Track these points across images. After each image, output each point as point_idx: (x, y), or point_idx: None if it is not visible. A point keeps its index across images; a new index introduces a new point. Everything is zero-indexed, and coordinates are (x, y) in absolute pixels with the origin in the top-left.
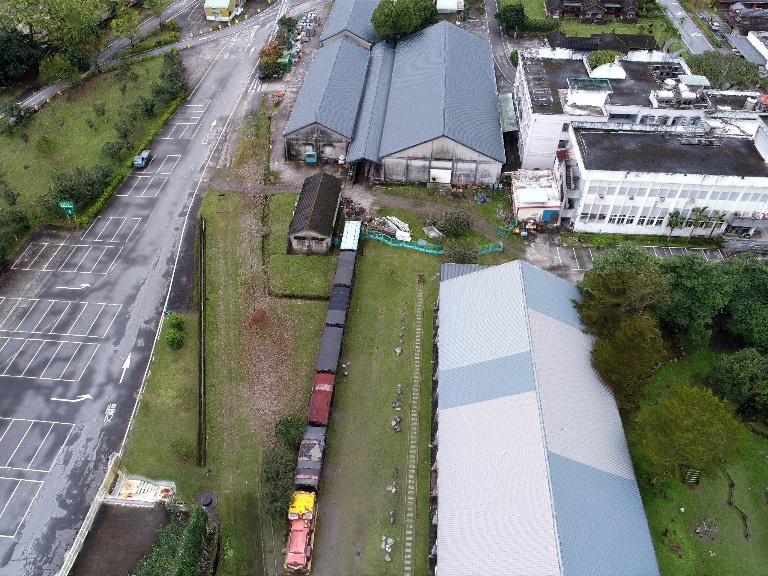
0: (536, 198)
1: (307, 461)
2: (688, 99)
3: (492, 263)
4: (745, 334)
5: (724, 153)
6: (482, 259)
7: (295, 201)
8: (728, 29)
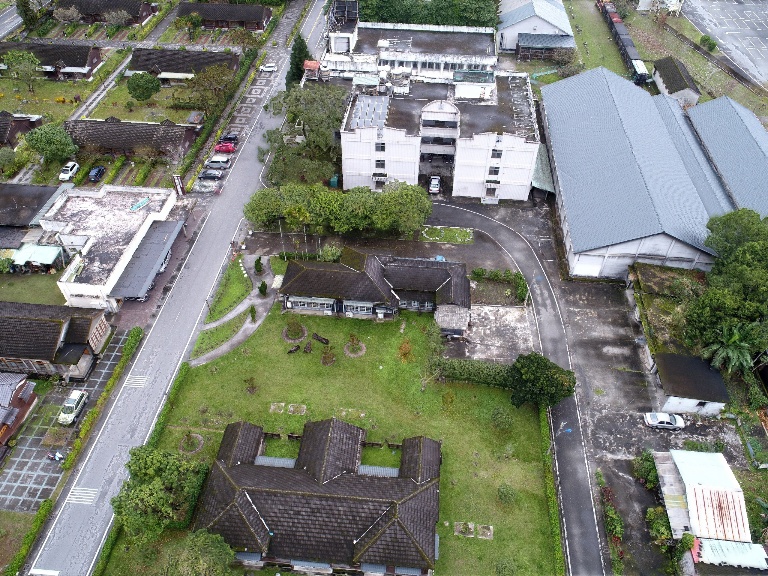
0: None
1: None
2: None
3: (540, 70)
4: None
5: None
6: None
7: None
8: (45, 406)
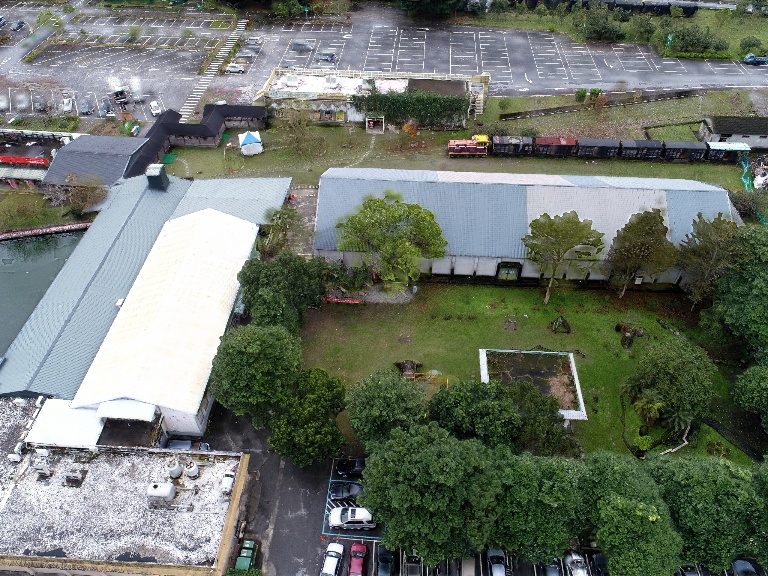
0: None
1: (508, 138)
2: None
3: None
4: None
5: None
6: None
7: None
8: None
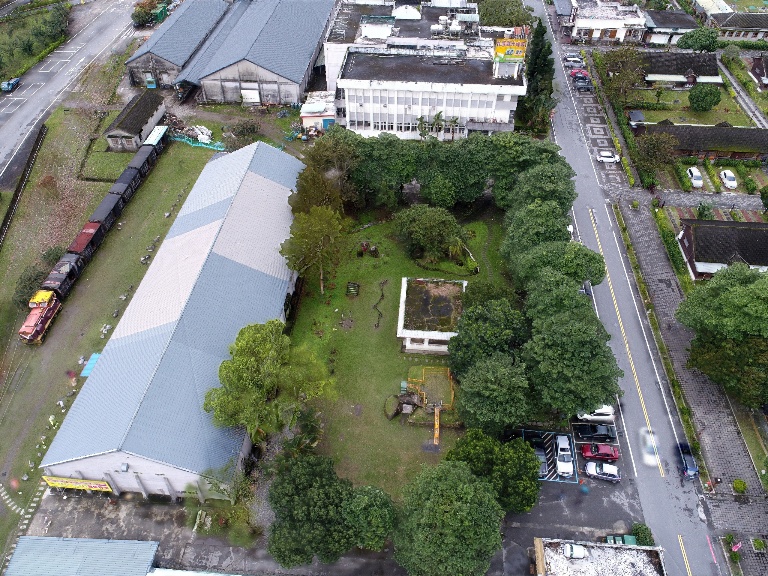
0: (315, 109)
1: (56, 273)
2: (455, 31)
3: None
4: (430, 197)
5: (464, 70)
6: None
7: None
8: None
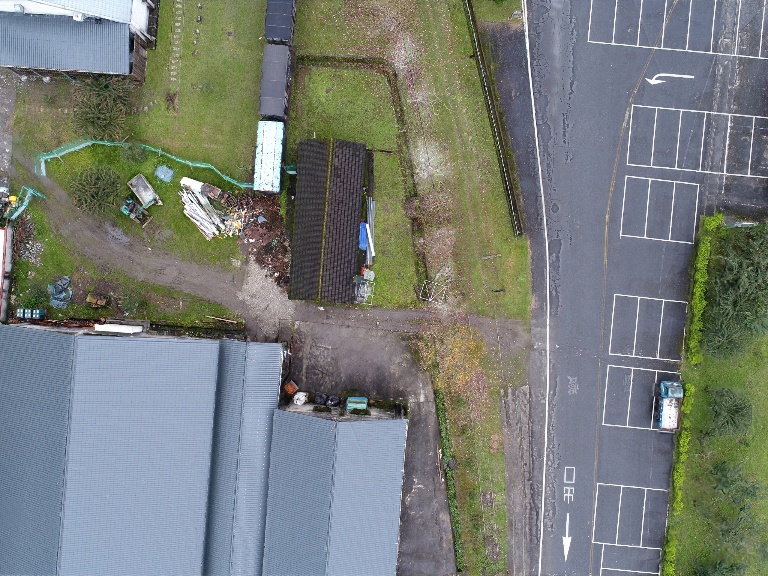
0: None
1: None
2: None
3: (63, 129)
4: None
5: None
6: (77, 138)
7: (375, 284)
8: None
